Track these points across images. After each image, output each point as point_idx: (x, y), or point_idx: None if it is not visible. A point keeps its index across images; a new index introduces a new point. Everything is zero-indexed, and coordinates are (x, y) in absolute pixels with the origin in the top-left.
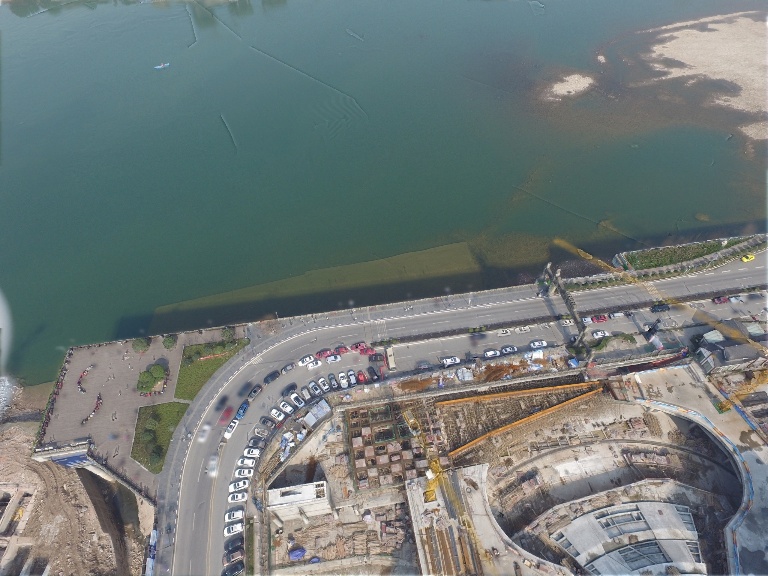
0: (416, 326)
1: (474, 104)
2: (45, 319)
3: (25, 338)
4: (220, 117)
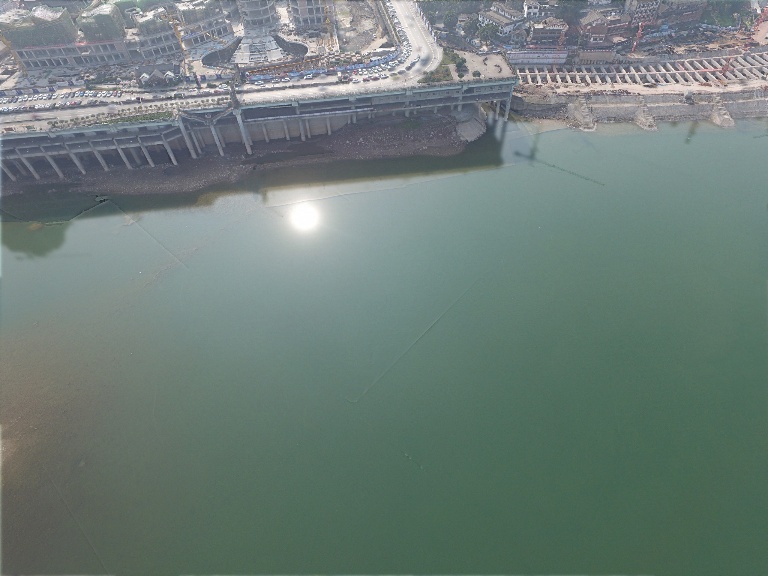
0: (323, 89)
1: (140, 443)
2: (593, 156)
3: (596, 148)
4: (613, 442)
